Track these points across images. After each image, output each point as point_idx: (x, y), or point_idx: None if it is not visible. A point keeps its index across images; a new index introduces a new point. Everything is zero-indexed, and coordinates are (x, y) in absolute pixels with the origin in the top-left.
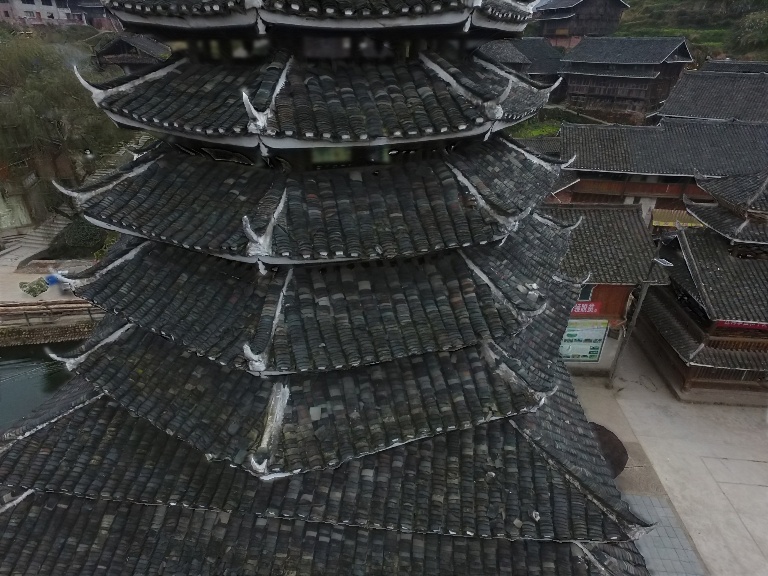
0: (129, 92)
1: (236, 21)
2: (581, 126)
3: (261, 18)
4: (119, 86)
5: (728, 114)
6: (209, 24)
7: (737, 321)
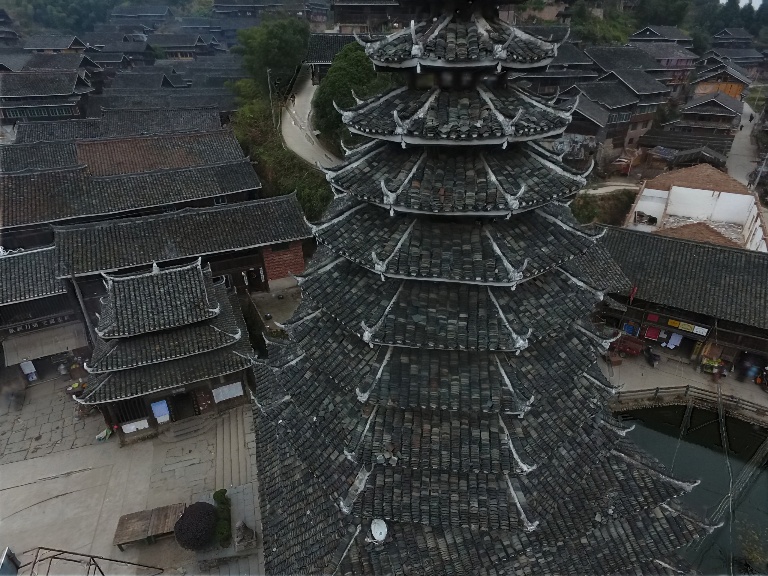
0: None
1: None
2: None
3: None
4: None
5: None
6: None
7: None
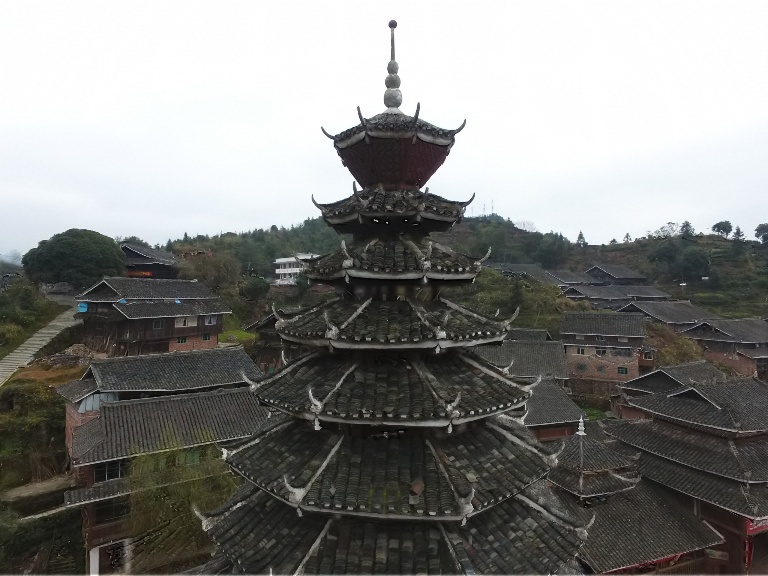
0: (301, 574)
1: (443, 518)
2: None
3: (466, 517)
4: (295, 572)
5: None
6: (411, 518)
7: (613, 570)
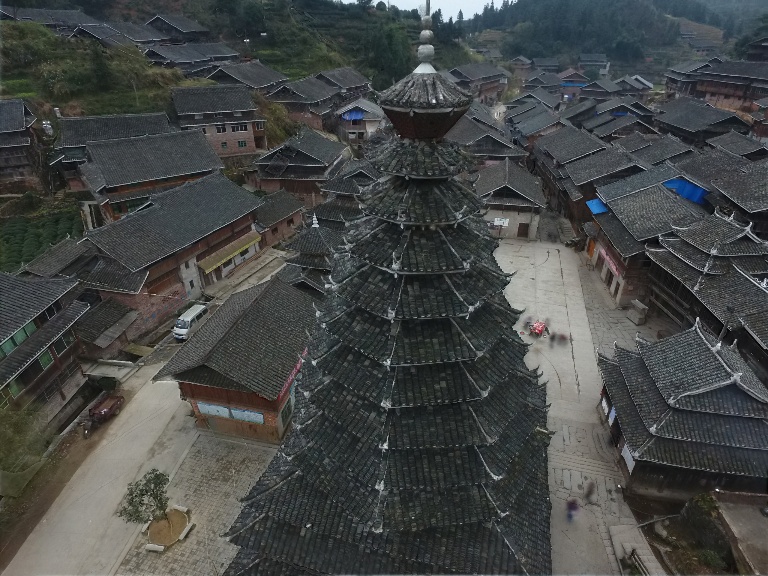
0: None
1: None
2: (103, 228)
3: None
4: None
5: (158, 173)
6: None
7: None
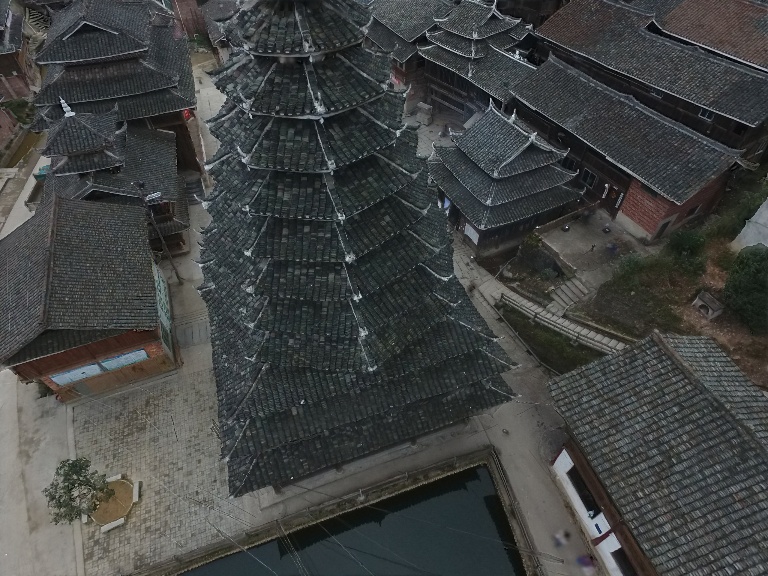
0: None
1: None
2: None
3: None
4: None
5: None
6: None
7: None
